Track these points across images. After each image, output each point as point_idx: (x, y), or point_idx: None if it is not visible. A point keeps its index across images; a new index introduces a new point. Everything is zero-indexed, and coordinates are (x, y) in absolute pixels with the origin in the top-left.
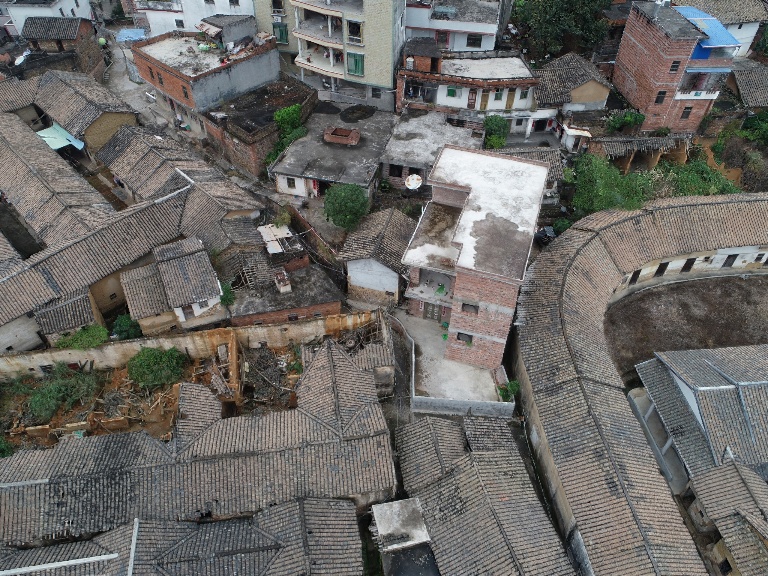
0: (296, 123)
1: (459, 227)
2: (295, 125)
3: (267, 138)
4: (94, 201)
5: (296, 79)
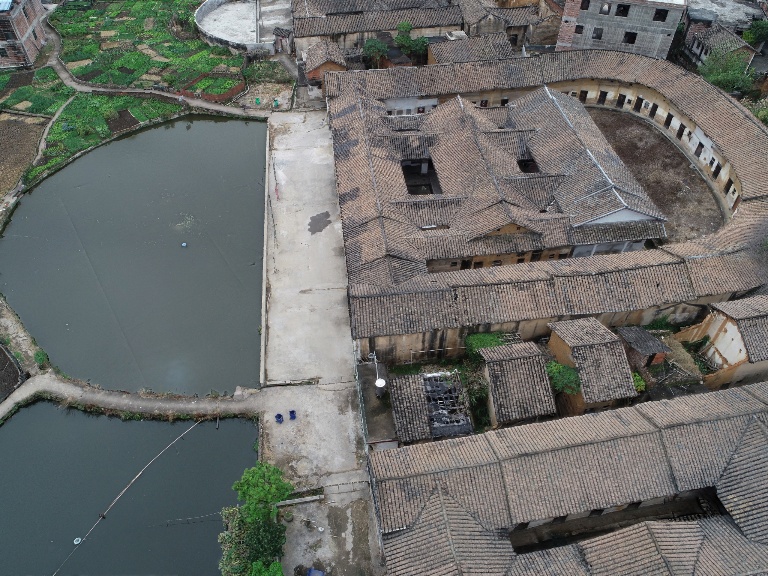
0: None
1: None
2: None
3: None
4: None
5: None
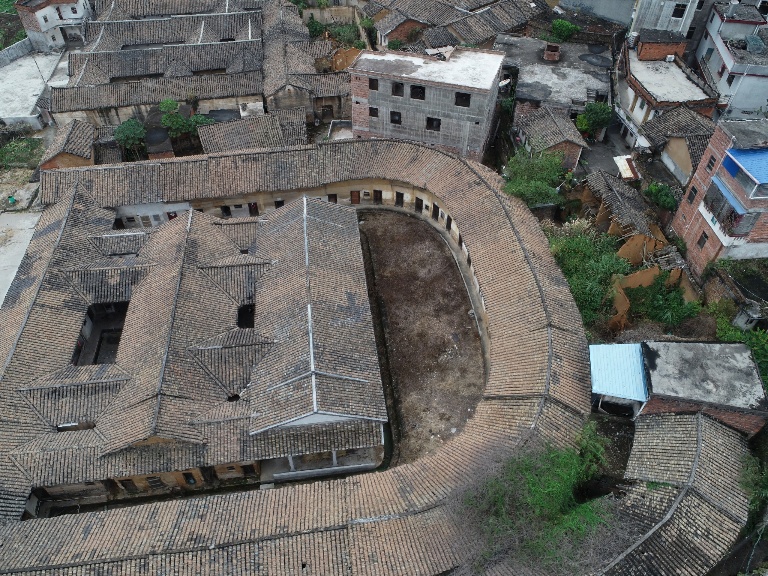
0: (563, 36)
1: (405, 56)
2: (562, 37)
3: (541, 31)
4: (466, 3)
5: (626, 27)
